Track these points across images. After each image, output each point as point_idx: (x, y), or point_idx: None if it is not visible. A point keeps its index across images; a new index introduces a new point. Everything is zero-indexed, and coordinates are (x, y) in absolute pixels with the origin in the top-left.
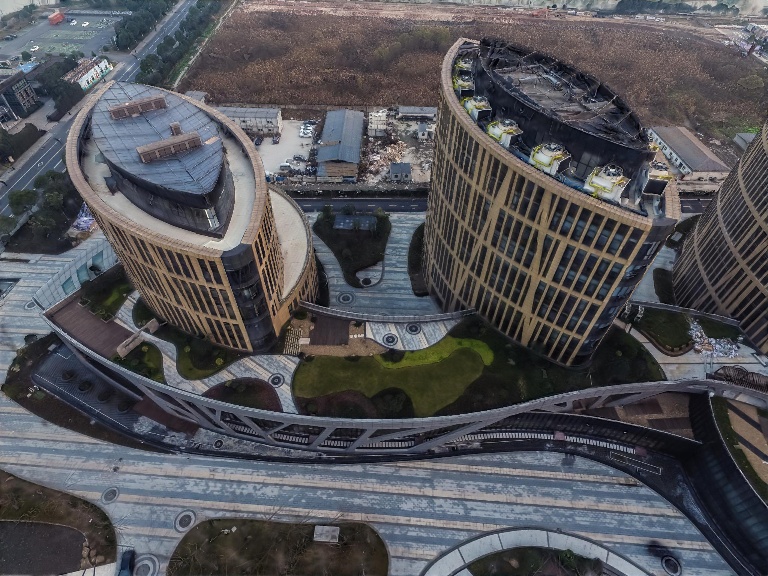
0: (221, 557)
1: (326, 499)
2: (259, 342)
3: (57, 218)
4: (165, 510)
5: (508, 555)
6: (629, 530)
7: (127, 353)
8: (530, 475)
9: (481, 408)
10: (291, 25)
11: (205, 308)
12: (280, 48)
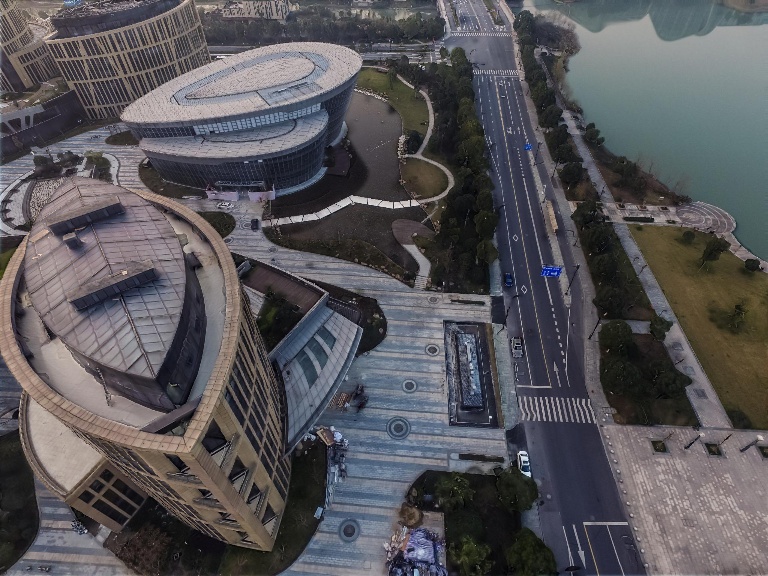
0: None
1: None
2: None
3: (452, 524)
4: (239, 244)
5: None
6: None
7: (247, 270)
8: None
9: (6, 241)
10: None
11: None
12: None
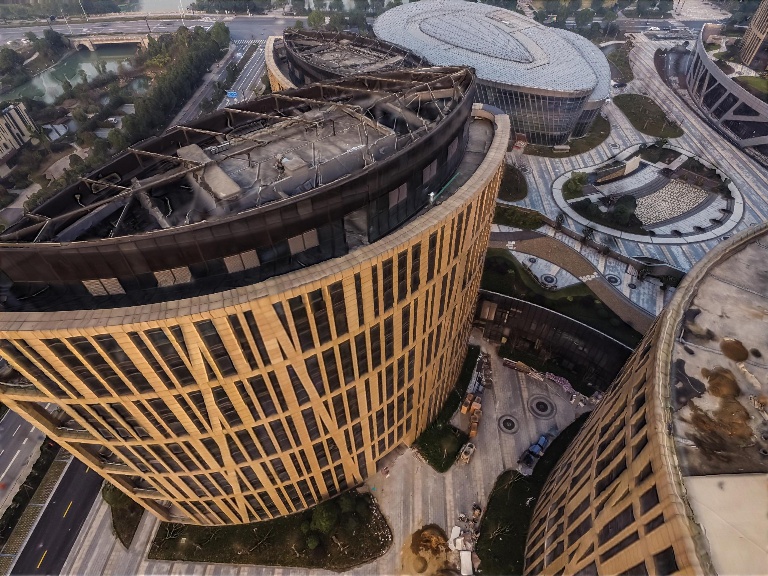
0: (640, 101)
1: (685, 122)
2: (756, 62)
3: None
4: None
5: (708, 168)
6: (766, 214)
7: None
8: (766, 182)
9: None
10: None
11: (760, 24)
12: None
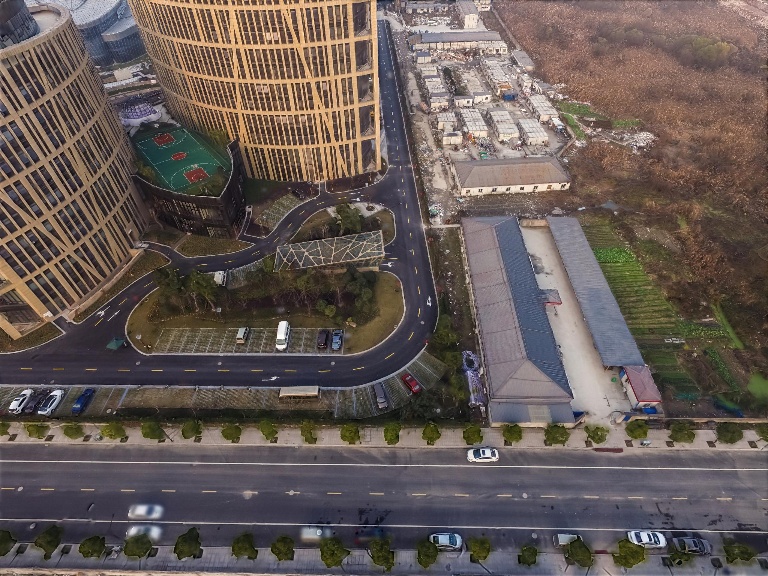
0: None
1: None
2: None
3: None
4: None
5: None
6: None
7: None
8: None
9: None
10: (673, 6)
11: None
12: (601, 6)
